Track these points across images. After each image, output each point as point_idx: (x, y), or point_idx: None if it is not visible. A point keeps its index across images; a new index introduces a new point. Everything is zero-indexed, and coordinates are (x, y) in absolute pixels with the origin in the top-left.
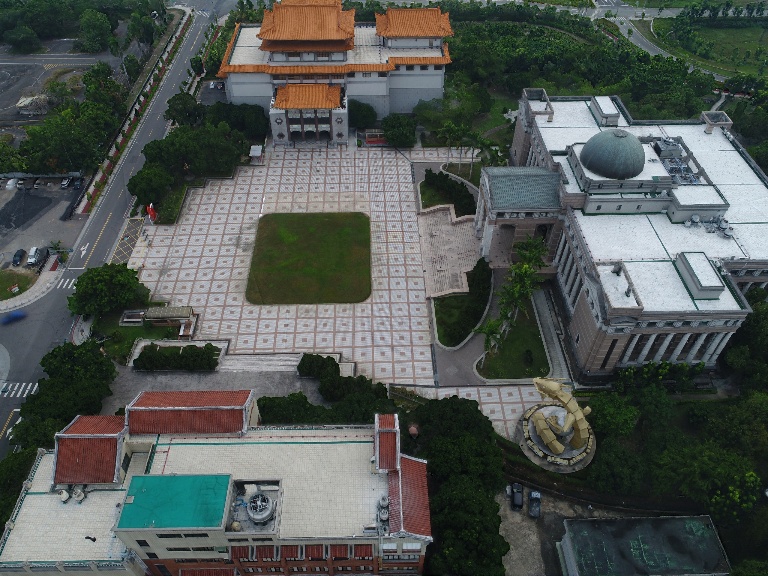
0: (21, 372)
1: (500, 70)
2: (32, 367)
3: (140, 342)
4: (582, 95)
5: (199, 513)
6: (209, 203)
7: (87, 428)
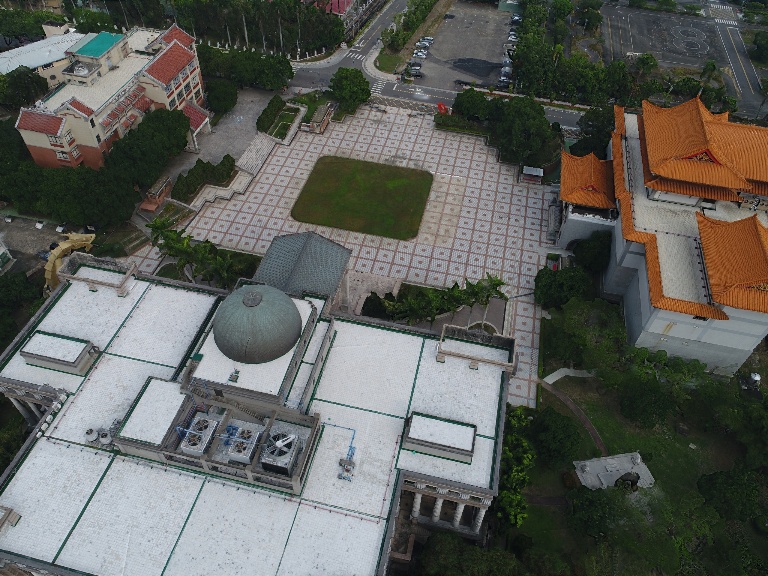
0: (306, 71)
1: (767, 469)
2: (307, 74)
3: (305, 108)
4: (638, 558)
5: (87, 49)
6: (460, 146)
7: (178, 36)
